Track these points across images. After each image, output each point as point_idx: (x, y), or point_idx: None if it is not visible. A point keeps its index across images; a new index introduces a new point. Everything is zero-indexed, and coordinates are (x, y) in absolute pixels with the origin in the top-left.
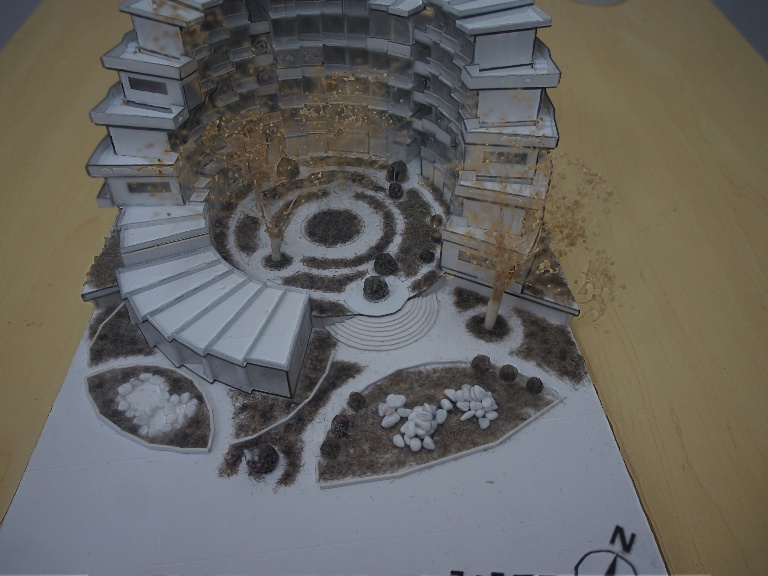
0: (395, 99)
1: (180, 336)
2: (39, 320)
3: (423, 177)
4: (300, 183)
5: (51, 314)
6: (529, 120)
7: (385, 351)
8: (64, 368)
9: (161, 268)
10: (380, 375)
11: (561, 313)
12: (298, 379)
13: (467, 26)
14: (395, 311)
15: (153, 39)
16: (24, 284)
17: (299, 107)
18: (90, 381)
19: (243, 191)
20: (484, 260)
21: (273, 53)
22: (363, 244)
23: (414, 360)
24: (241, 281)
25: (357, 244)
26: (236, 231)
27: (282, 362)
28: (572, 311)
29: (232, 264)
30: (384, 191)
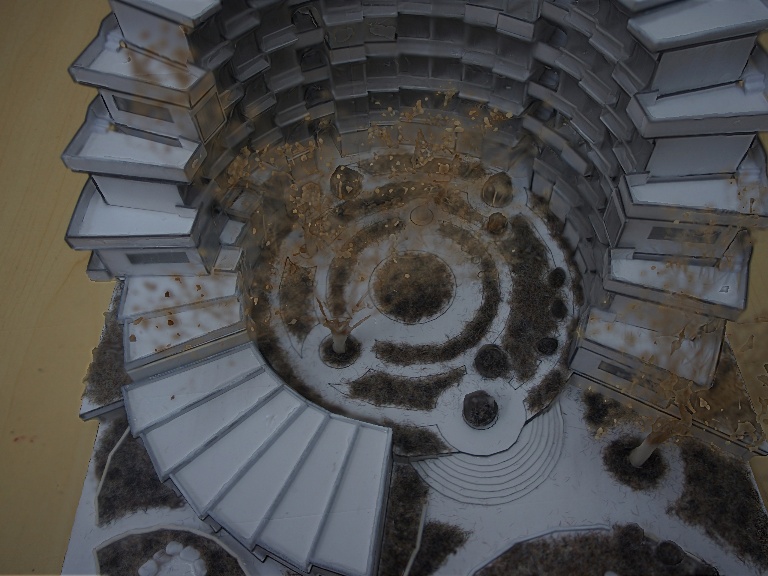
0: (499, 86)
1: (217, 510)
2: (29, 432)
3: (533, 194)
4: (364, 208)
5: (44, 421)
6: (724, 172)
7: (495, 505)
8: (67, 517)
9: (183, 379)
10: (490, 548)
11: (740, 448)
12: (379, 558)
13: (649, 34)
14: (508, 447)
15: (144, 33)
16: (6, 368)
17: (360, 96)
18: (101, 553)
19: (286, 221)
20: (638, 377)
21: (323, 27)
22: (456, 318)
23: (536, 522)
24: (295, 409)
25: (448, 318)
26: (281, 295)
27: (361, 567)
28: (759, 451)
29: (279, 357)
30: (480, 220)
